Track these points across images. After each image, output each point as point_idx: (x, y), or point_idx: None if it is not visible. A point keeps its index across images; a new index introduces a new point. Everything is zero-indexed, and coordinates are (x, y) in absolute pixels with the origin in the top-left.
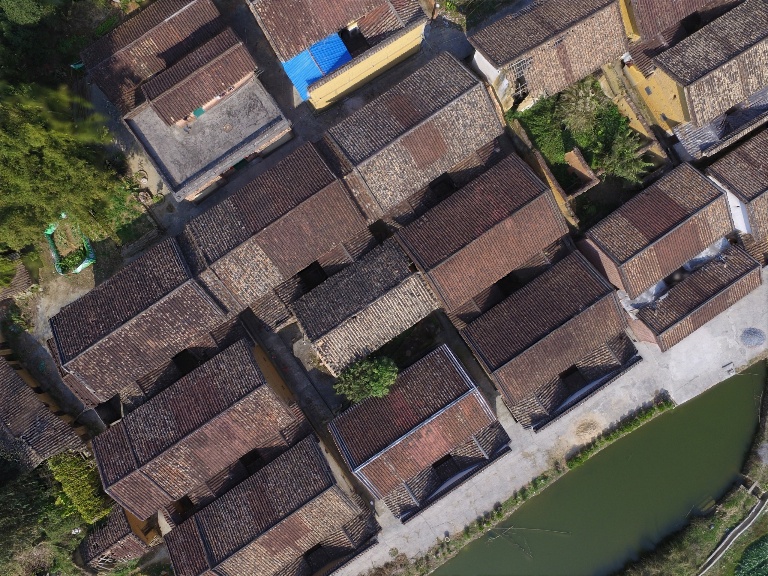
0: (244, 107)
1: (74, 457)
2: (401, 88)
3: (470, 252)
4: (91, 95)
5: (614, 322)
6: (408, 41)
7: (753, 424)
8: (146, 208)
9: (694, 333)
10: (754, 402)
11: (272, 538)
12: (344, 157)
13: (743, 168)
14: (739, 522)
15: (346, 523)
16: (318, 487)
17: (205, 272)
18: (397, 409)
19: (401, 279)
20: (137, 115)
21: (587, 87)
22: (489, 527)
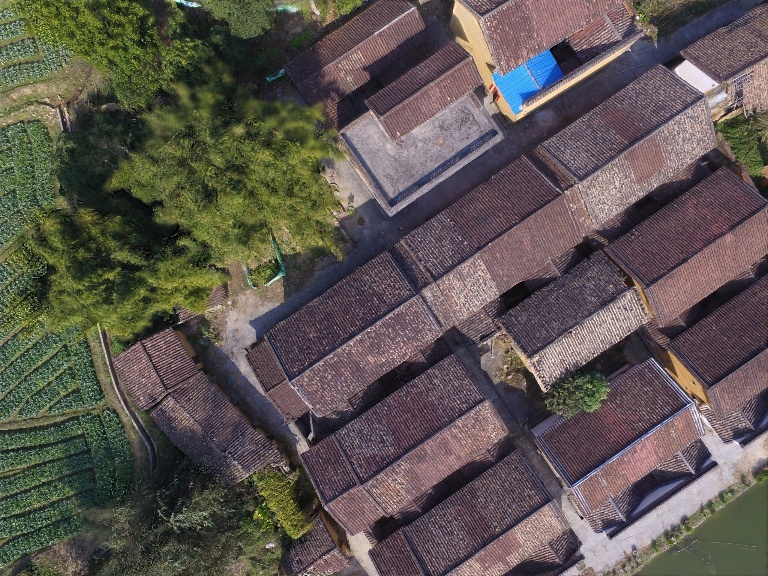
0: (456, 121)
1: (276, 472)
2: (615, 102)
3: (690, 267)
4: (282, 107)
5: None
6: (616, 54)
7: None
8: (338, 221)
9: None
10: None
11: (487, 554)
12: (566, 171)
13: None
14: None
15: None
16: (534, 503)
17: (427, 287)
18: (609, 424)
19: (617, 294)
20: (350, 129)
21: None
22: (676, 541)
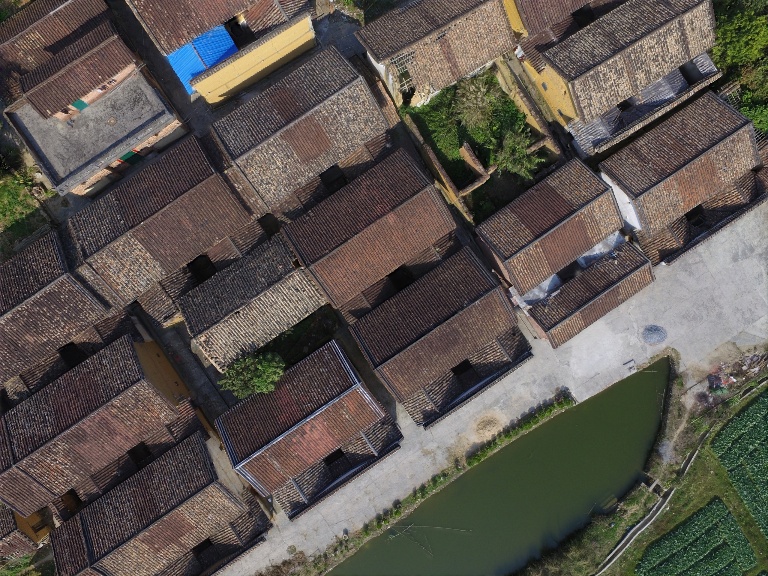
0: (128, 101)
1: None
2: (286, 82)
3: (352, 247)
4: None
5: (502, 318)
6: (297, 35)
7: (656, 422)
8: (40, 202)
9: (595, 330)
10: (656, 400)
11: (154, 535)
12: (224, 151)
13: (633, 164)
14: (640, 520)
15: (234, 520)
16: (200, 484)
17: (83, 266)
18: (282, 405)
19: (284, 274)
20: (20, 108)
21: (480, 82)
22: (388, 525)
